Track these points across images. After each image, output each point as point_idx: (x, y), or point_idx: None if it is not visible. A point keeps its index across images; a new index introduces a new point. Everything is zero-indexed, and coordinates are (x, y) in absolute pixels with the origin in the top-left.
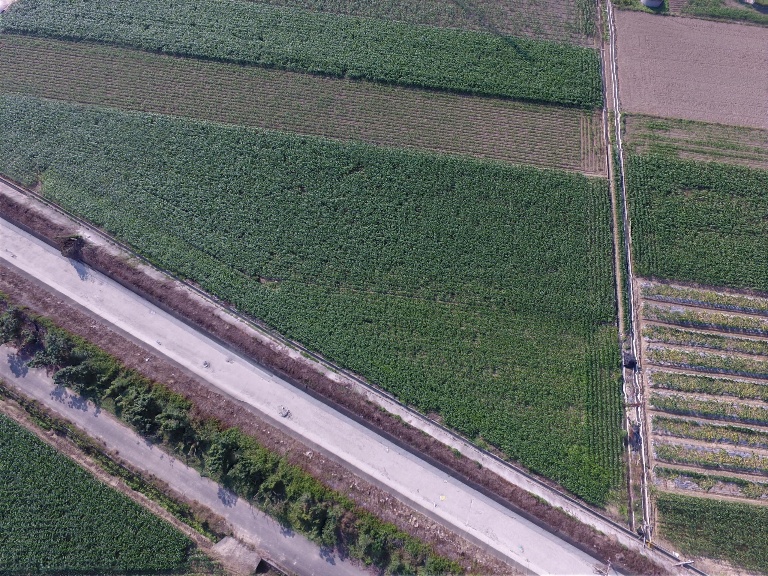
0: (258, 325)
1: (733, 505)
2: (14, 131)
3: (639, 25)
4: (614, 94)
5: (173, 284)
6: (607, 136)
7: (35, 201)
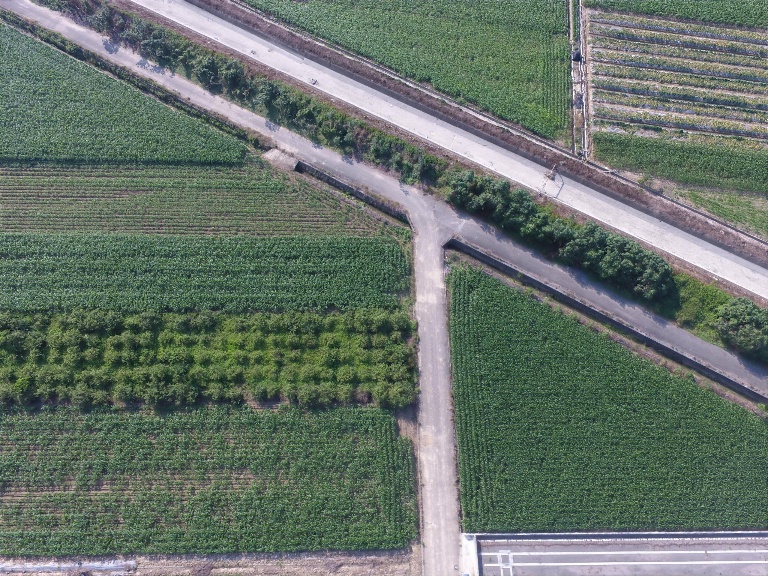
0: (292, 29)
1: (650, 138)
2: None
3: None
4: None
5: (226, 0)
6: None
7: None
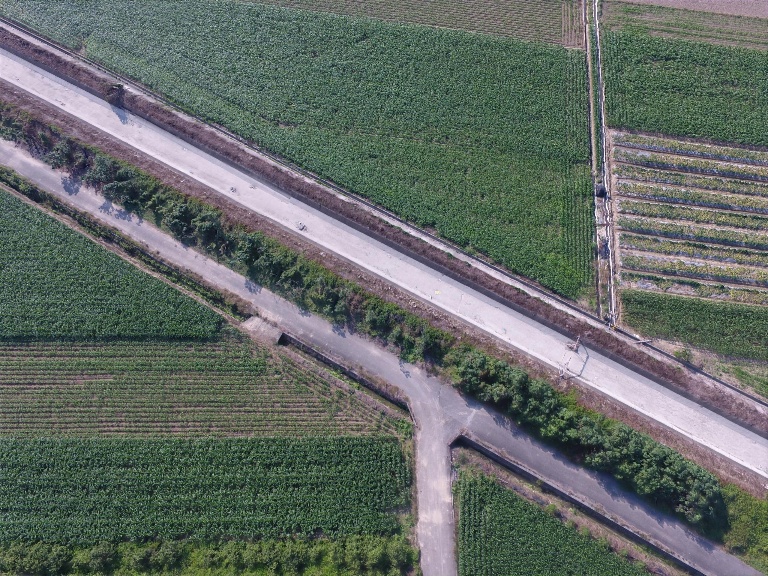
0: (277, 160)
1: (686, 298)
2: (60, 5)
3: None
4: None
5: (203, 126)
6: (585, 18)
7: (80, 61)
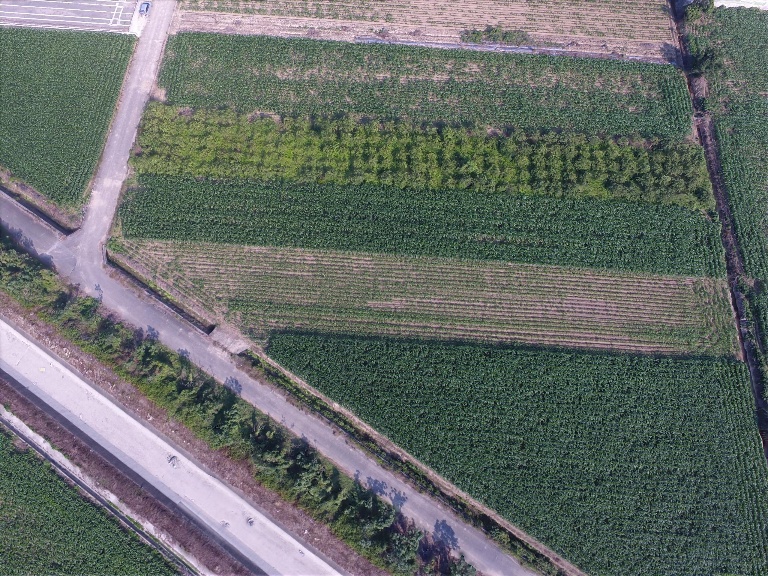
0: (188, 569)
1: None
2: None
3: None
4: None
5: None
6: None
7: None
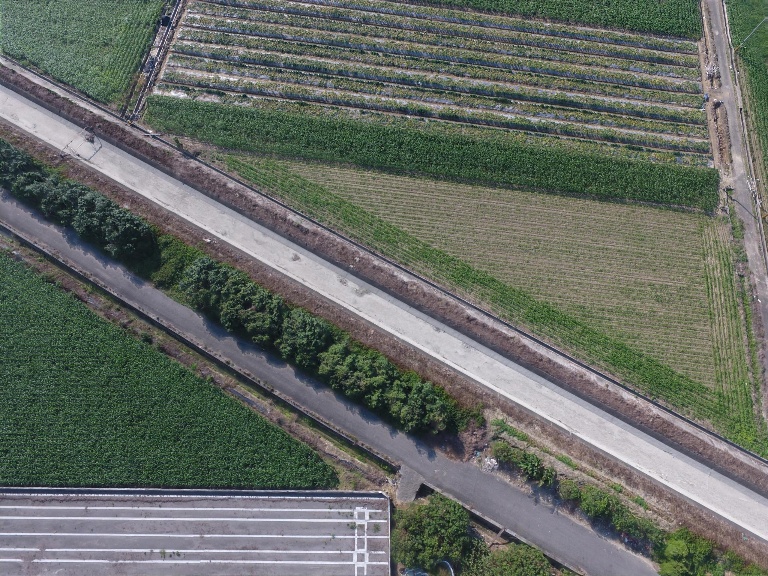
0: None
1: (203, 102)
2: None
3: None
4: None
5: None
6: None
7: None
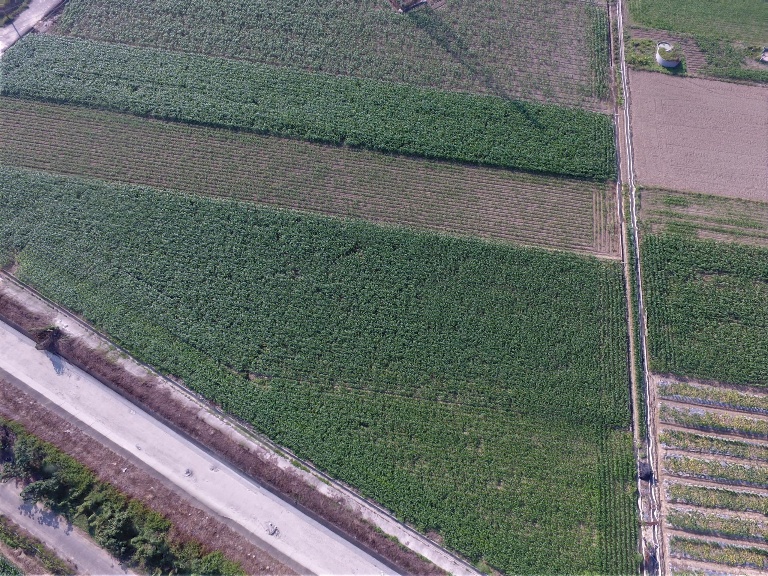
0: (245, 428)
1: None
2: None
3: (655, 87)
4: (629, 165)
5: (155, 381)
6: (621, 212)
7: (10, 284)
